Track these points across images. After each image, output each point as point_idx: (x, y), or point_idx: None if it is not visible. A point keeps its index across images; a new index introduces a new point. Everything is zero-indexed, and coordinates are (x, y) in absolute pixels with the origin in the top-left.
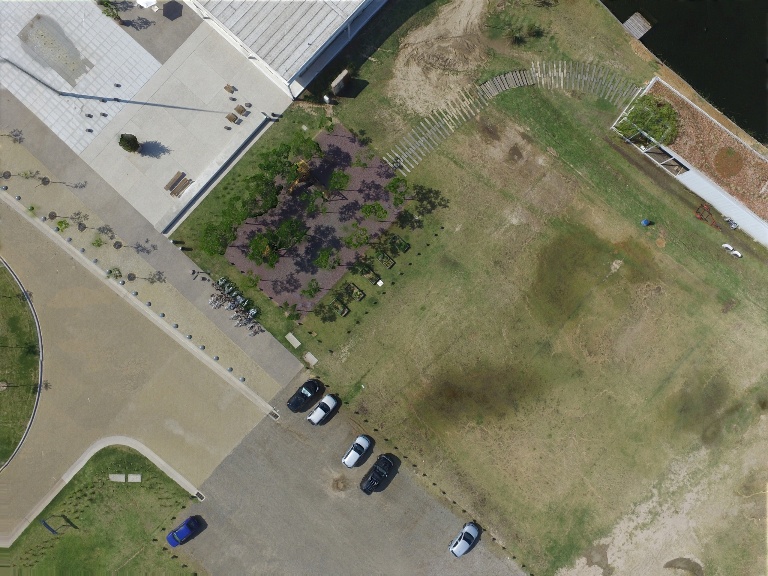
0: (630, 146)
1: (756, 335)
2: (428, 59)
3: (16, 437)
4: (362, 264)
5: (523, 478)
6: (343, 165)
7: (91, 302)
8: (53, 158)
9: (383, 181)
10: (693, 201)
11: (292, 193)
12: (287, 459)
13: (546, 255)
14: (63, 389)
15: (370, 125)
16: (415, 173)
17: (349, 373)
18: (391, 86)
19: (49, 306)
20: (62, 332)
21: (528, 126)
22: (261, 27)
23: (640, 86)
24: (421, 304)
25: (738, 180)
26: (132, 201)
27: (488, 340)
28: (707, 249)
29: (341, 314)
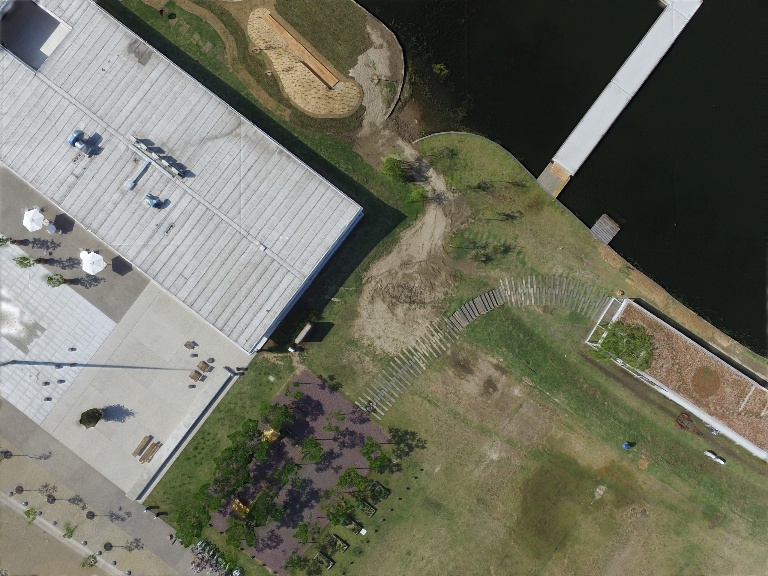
0: None
1: (743, 548)
2: (393, 291)
3: None
4: (343, 514)
5: None
6: (315, 414)
7: (69, 575)
8: (13, 430)
9: (357, 427)
10: (673, 409)
11: None
12: None
13: (529, 488)
14: None
15: (339, 369)
16: (389, 416)
17: None
18: (357, 326)
19: None
20: None
21: (501, 356)
22: (216, 296)
23: (612, 295)
24: (406, 549)
25: (717, 399)
26: (100, 469)
27: None
28: (690, 460)
29: (326, 568)
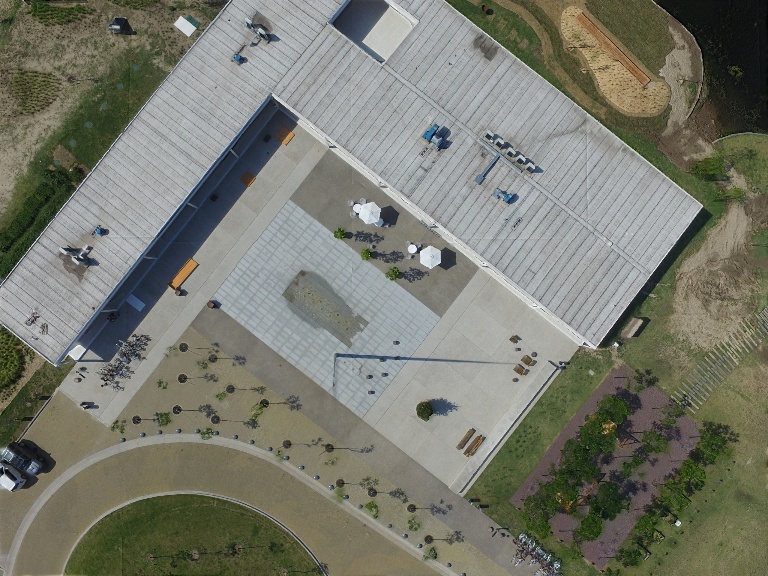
0: None
1: None
2: (703, 288)
3: None
4: (659, 506)
5: None
6: (633, 408)
7: (389, 568)
8: (335, 423)
9: None
10: None
11: None
12: None
13: None
14: None
15: (656, 364)
16: (704, 410)
17: None
18: (673, 322)
19: None
20: None
21: None
22: (563, 290)
23: None
24: (718, 540)
25: None
26: (422, 462)
27: None
28: None
29: (643, 558)
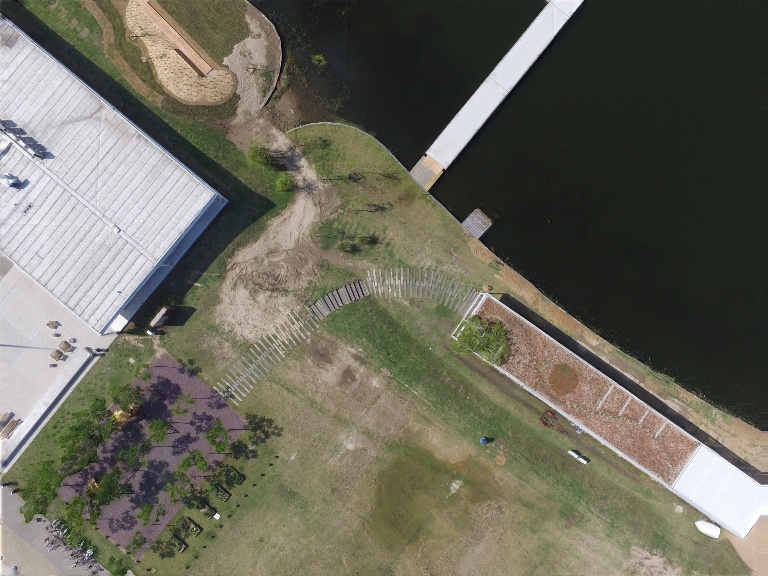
0: (472, 353)
1: (600, 549)
2: (257, 279)
3: None
4: (197, 498)
5: None
6: (173, 397)
7: None
8: None
9: (214, 412)
10: (538, 406)
11: (122, 430)
12: None
13: (384, 479)
14: None
15: (199, 354)
16: (247, 402)
17: None
18: (219, 312)
19: None
20: None
21: (360, 347)
22: (69, 276)
23: (480, 290)
24: (259, 536)
25: (574, 397)
26: None
27: (328, 569)
28: (551, 459)
29: (178, 551)
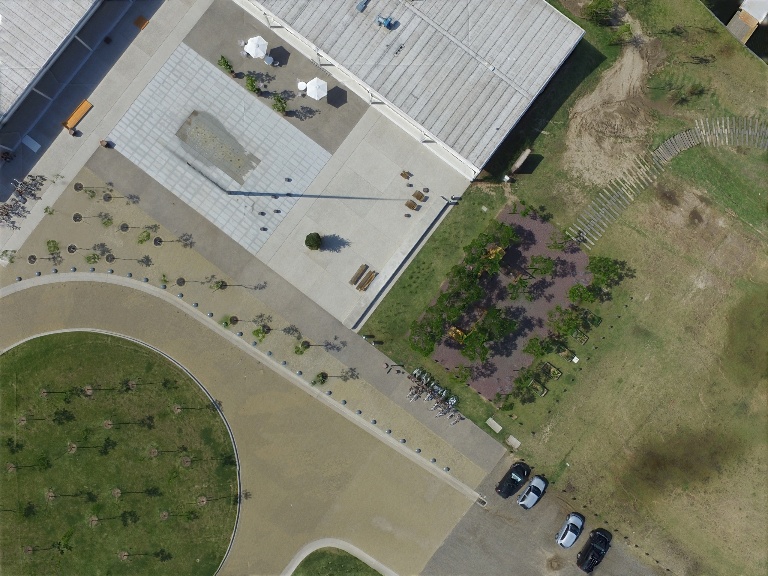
0: None
1: None
2: (598, 127)
3: (220, 551)
4: (556, 342)
5: (732, 539)
6: (527, 243)
7: (283, 406)
8: (228, 261)
9: (569, 256)
10: None
11: (480, 277)
12: (499, 544)
13: (734, 316)
14: (264, 497)
15: (550, 200)
16: (599, 245)
17: (553, 452)
18: (566, 159)
19: (240, 414)
20: (257, 439)
21: (705, 188)
22: (446, 114)
23: None
24: (618, 377)
25: None
26: (316, 298)
27: (686, 406)
28: None
29: (541, 395)
